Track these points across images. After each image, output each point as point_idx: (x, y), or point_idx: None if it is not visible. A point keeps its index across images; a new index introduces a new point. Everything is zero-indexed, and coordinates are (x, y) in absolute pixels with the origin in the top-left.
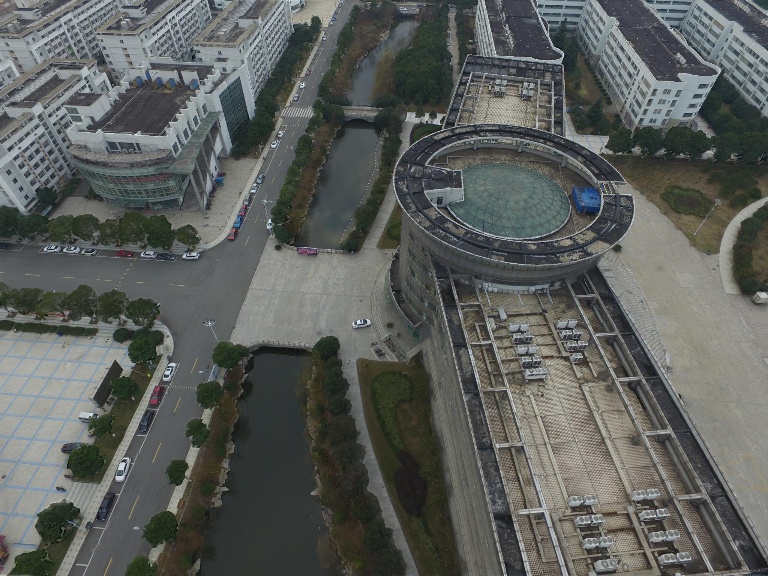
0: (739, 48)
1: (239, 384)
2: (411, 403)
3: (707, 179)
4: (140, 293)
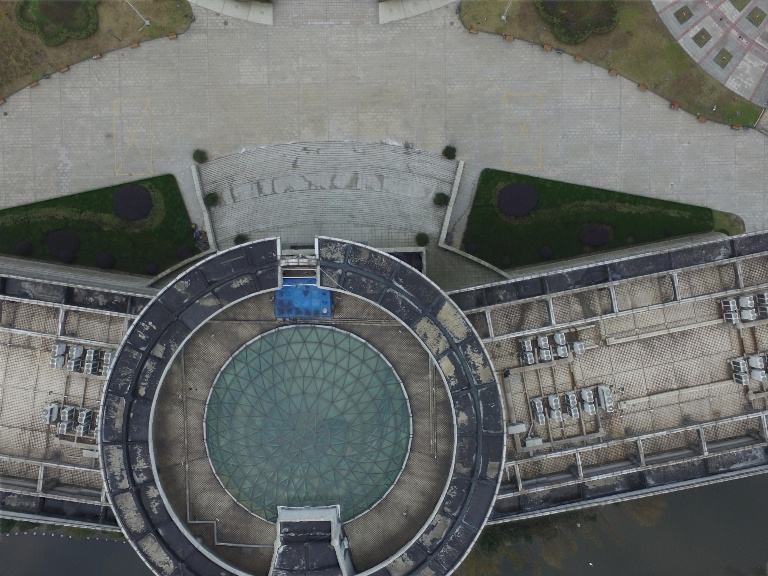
0: None
1: None
2: None
3: None
4: None
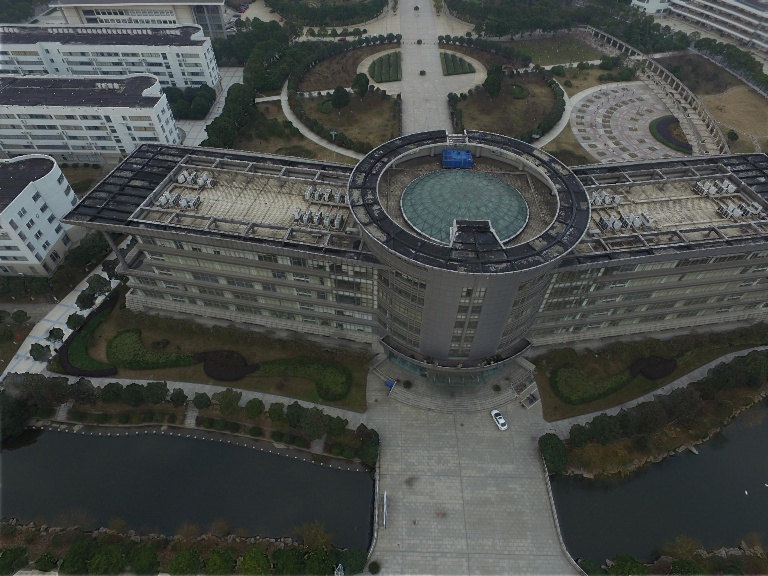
0: (84, 58)
1: None
2: (579, 368)
3: (265, 140)
4: None
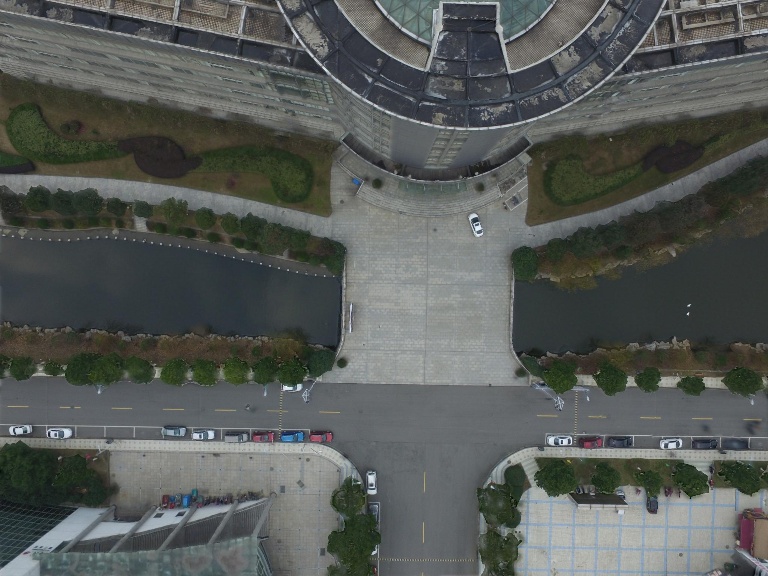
0: None
1: (563, 358)
2: (583, 159)
3: None
4: (442, 525)
